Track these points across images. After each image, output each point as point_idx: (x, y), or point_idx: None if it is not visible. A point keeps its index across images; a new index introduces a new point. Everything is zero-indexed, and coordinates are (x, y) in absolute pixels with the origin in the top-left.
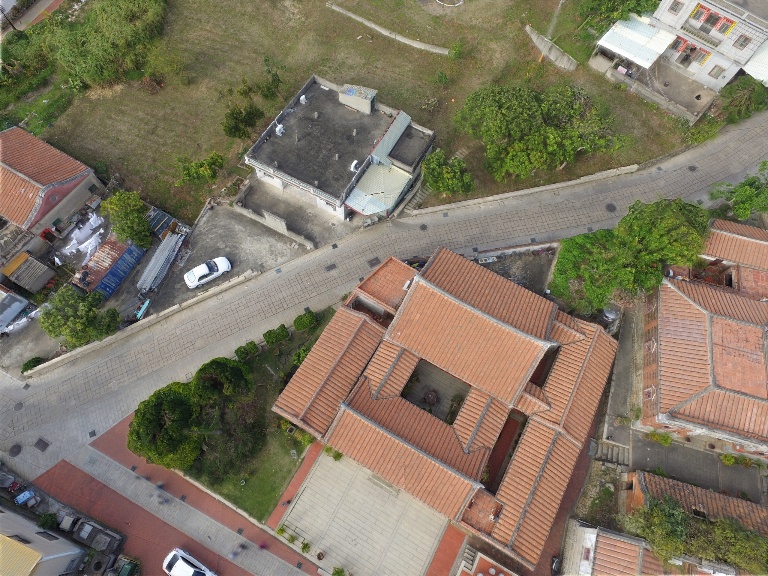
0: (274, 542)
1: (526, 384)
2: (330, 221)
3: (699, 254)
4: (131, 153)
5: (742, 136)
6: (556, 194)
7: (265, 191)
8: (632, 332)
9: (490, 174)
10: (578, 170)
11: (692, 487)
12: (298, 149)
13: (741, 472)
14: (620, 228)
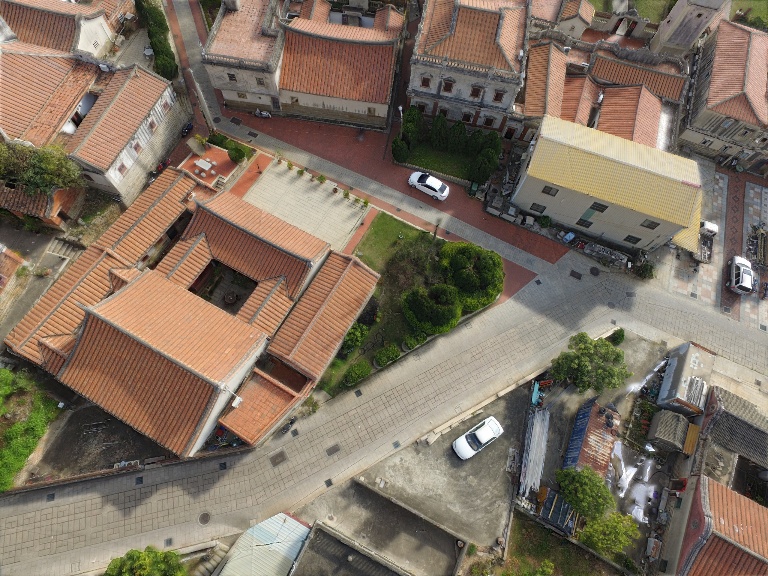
0: (372, 202)
1: None
2: (335, 524)
3: None
4: None
5: None
6: None
7: (431, 575)
8: None
9: None
10: None
11: (4, 205)
12: None
13: None
14: None
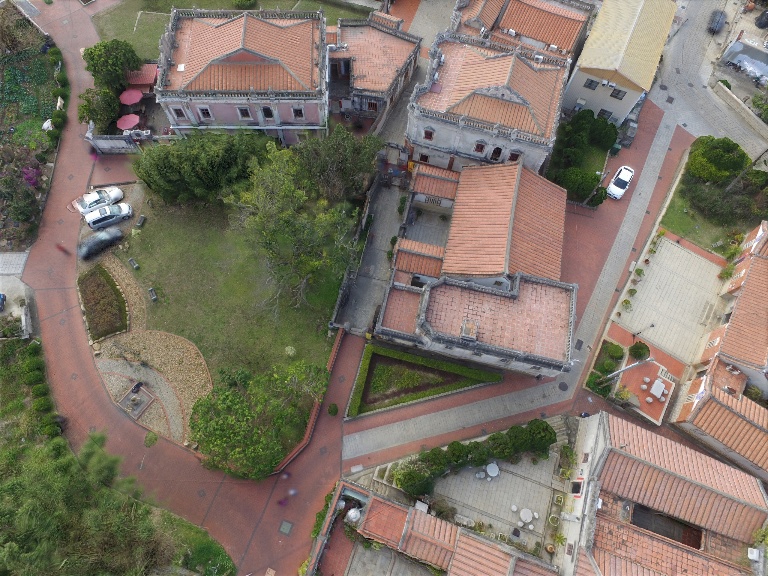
0: (646, 233)
1: None
2: None
3: None
4: None
5: None
6: None
7: None
8: None
9: None
10: None
11: None
12: None
13: None
14: None
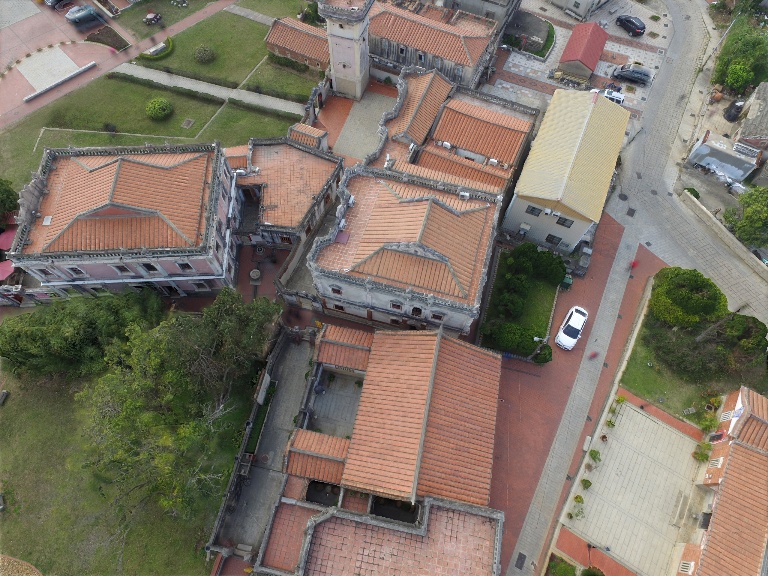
0: (604, 395)
1: None
2: None
3: None
4: None
5: None
6: None
7: None
8: None
9: None
10: None
11: None
12: None
13: None
14: None
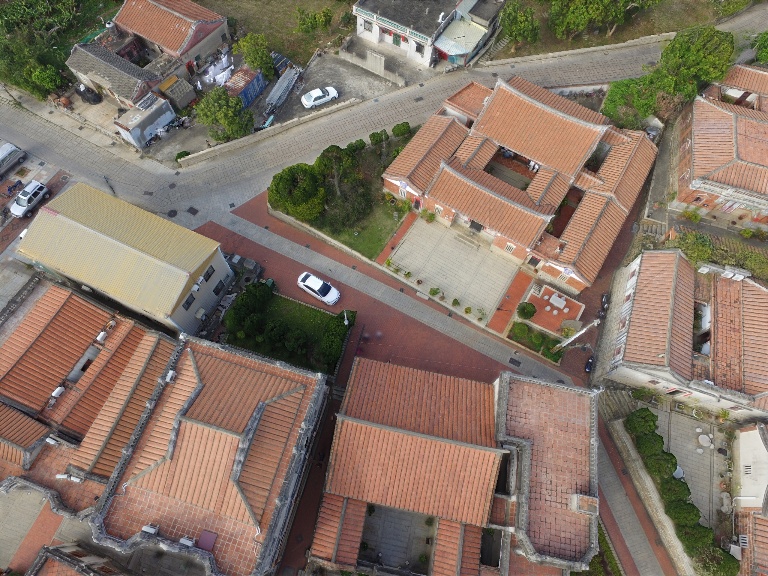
0: (381, 275)
1: (584, 169)
2: (417, 67)
3: (727, 88)
4: (251, 17)
5: (766, 14)
6: (606, 54)
7: (363, 44)
8: (669, 148)
9: (552, 31)
10: (625, 37)
11: (718, 236)
12: (395, 6)
13: (757, 245)
14: (663, 54)
